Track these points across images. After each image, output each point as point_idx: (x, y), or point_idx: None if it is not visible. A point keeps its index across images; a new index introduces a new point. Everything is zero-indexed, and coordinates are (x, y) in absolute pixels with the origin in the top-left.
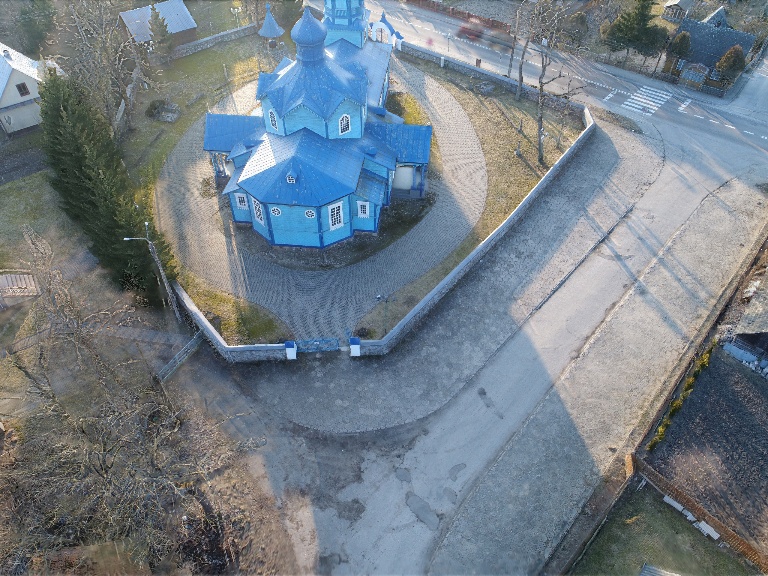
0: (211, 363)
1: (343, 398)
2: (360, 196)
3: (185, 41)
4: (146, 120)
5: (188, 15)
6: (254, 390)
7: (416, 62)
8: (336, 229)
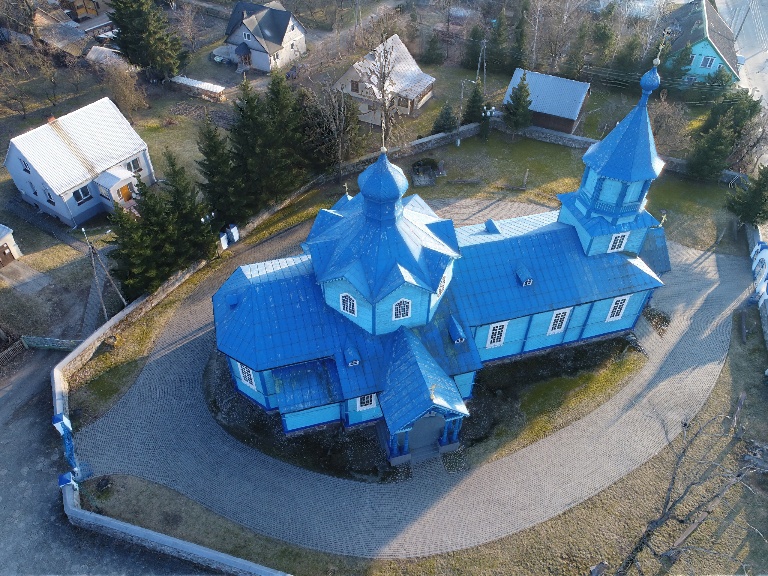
0: None
1: (3, 502)
2: (274, 382)
3: (556, 127)
4: (406, 169)
5: (579, 104)
6: (20, 417)
7: (743, 336)
8: (250, 387)
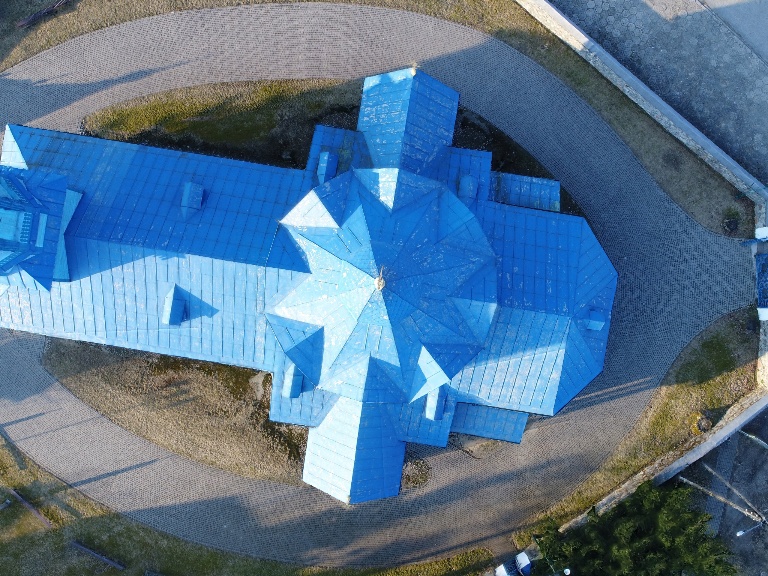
0: (766, 412)
1: None
2: None
3: None
4: None
5: None
6: None
7: None
8: None
